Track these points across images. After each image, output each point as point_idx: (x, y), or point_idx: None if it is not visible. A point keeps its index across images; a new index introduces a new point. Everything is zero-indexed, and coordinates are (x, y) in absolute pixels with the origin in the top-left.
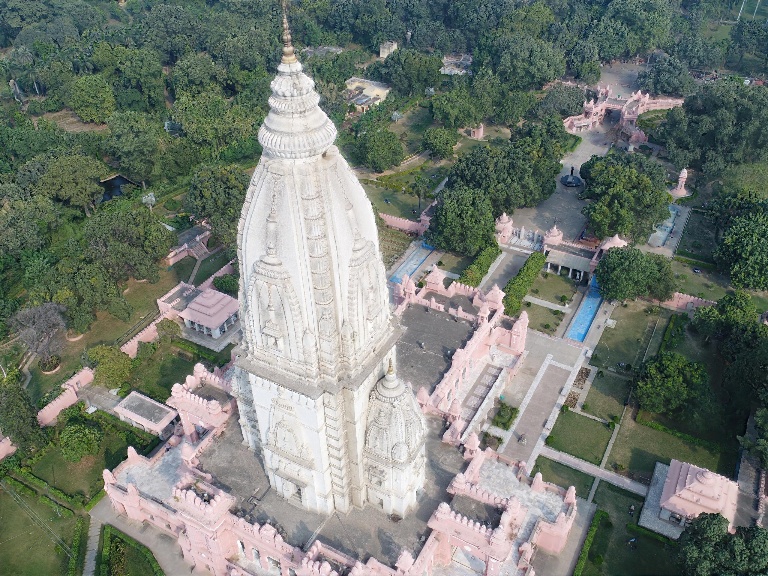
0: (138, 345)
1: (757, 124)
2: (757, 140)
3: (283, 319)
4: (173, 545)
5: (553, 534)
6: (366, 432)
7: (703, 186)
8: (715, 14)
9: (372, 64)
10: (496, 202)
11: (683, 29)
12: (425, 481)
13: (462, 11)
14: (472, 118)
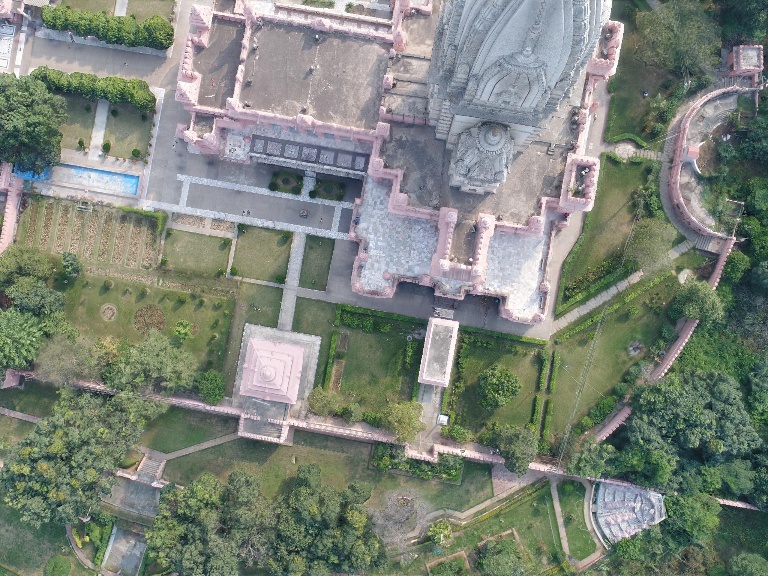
0: None
1: None
2: None
3: None
4: None
5: None
6: None
7: None
8: None
9: None
10: None
11: None
12: None
13: None
14: None
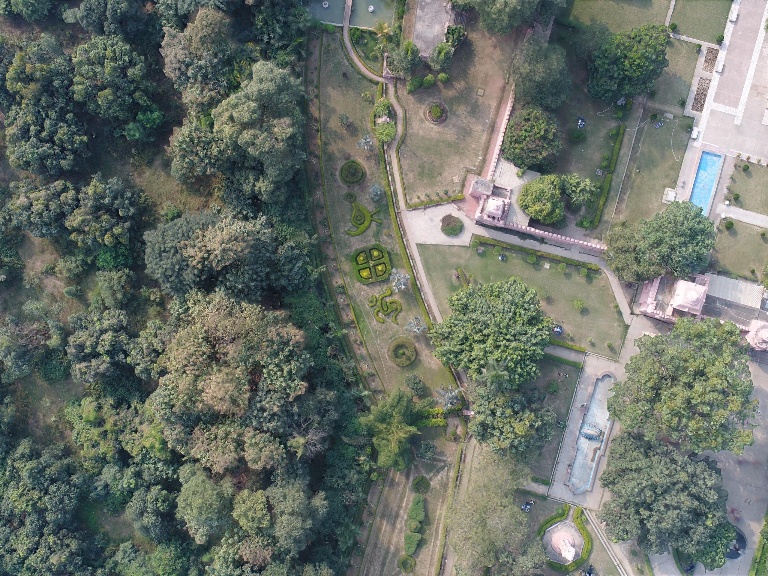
0: None
1: None
2: None
3: None
4: None
5: None
6: None
7: None
8: None
9: None
10: None
11: None
12: None
13: None
14: None
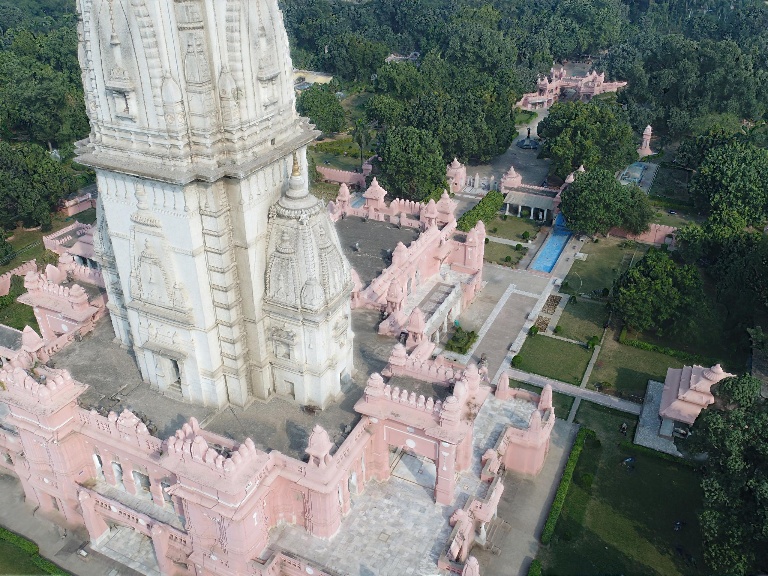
0: (10, 279)
1: (722, 72)
2: (723, 91)
3: (132, 57)
4: (14, 486)
5: (526, 444)
6: (265, 271)
7: (669, 143)
8: (663, 23)
9: (315, 56)
10: (446, 148)
11: (633, 33)
12: (354, 371)
13: (410, 16)
14: (420, 87)
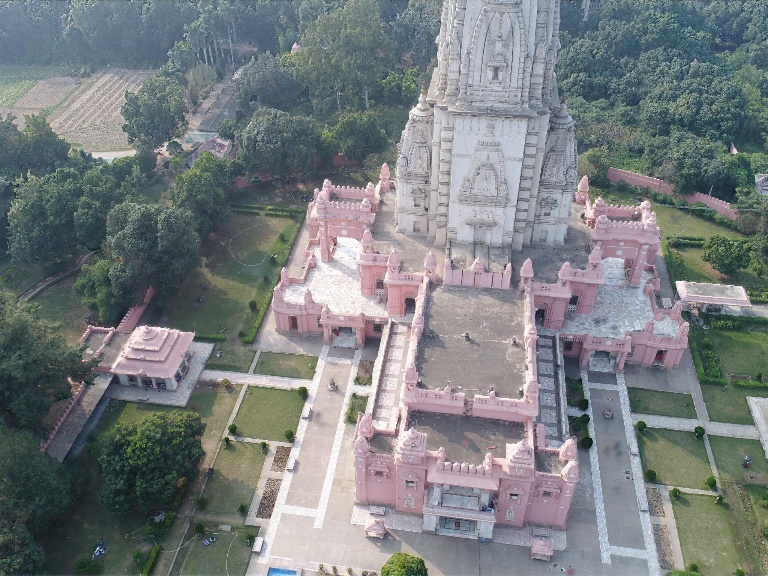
0: None
1: None
2: None
3: None
4: None
5: None
6: None
7: None
8: None
9: None
10: None
11: None
12: None
13: None
14: None
